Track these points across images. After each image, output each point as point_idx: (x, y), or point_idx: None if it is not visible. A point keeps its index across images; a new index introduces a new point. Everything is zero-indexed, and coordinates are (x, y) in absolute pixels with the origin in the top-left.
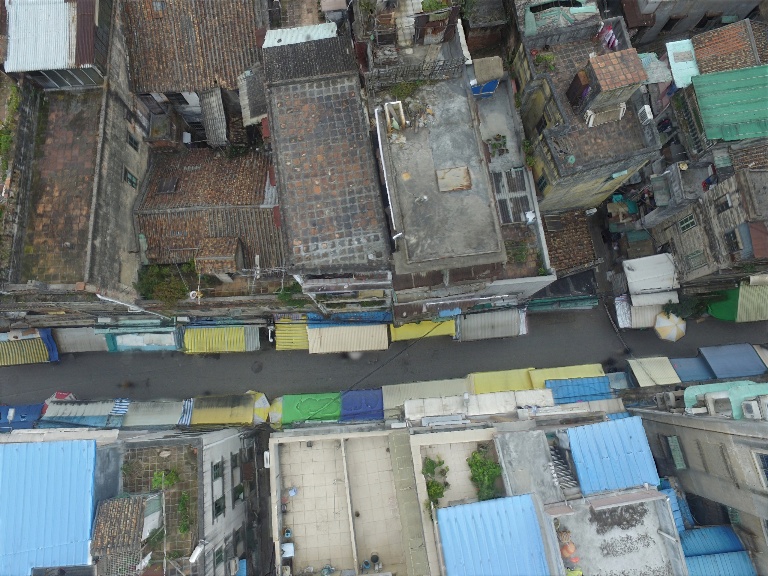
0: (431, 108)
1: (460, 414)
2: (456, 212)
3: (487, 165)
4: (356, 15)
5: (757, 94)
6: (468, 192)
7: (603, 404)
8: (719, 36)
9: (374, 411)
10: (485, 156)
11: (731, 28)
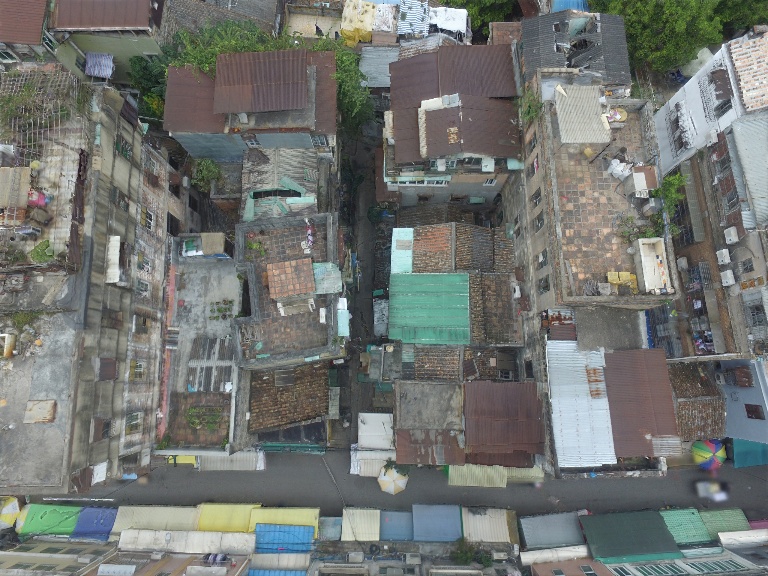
0: (42, 338)
1: (157, 554)
2: (35, 442)
3: (75, 400)
4: (5, 237)
5: (440, 301)
6: (51, 424)
7: (292, 558)
8: (432, 233)
9: (97, 534)
10: (75, 391)
11: (441, 228)
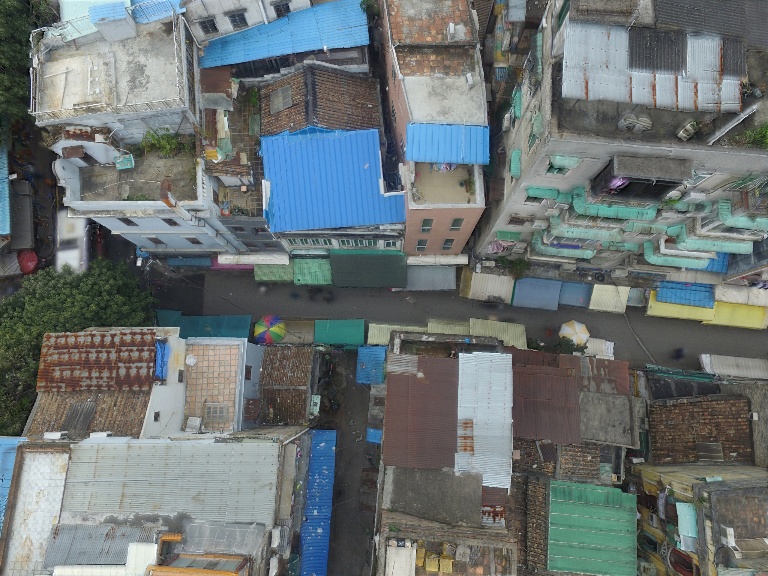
0: None
1: None
2: None
3: None
4: None
5: (580, 536)
6: None
7: (684, 278)
8: None
9: None
10: None
11: None
